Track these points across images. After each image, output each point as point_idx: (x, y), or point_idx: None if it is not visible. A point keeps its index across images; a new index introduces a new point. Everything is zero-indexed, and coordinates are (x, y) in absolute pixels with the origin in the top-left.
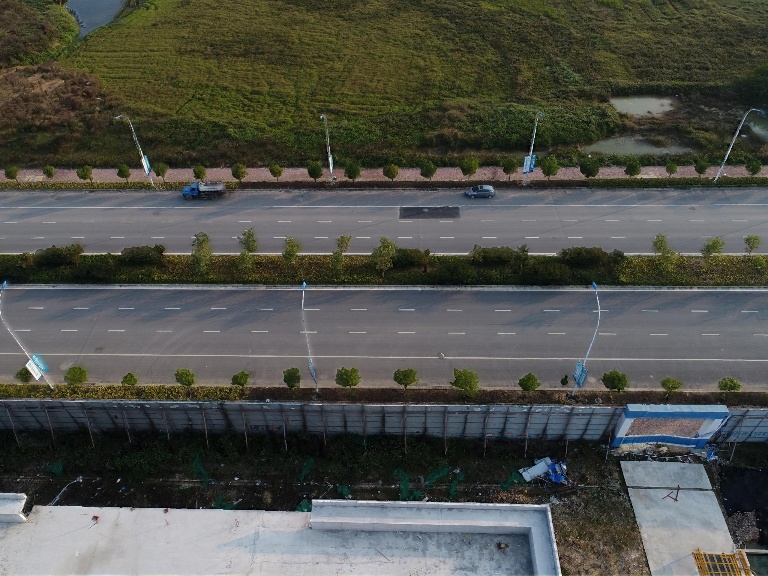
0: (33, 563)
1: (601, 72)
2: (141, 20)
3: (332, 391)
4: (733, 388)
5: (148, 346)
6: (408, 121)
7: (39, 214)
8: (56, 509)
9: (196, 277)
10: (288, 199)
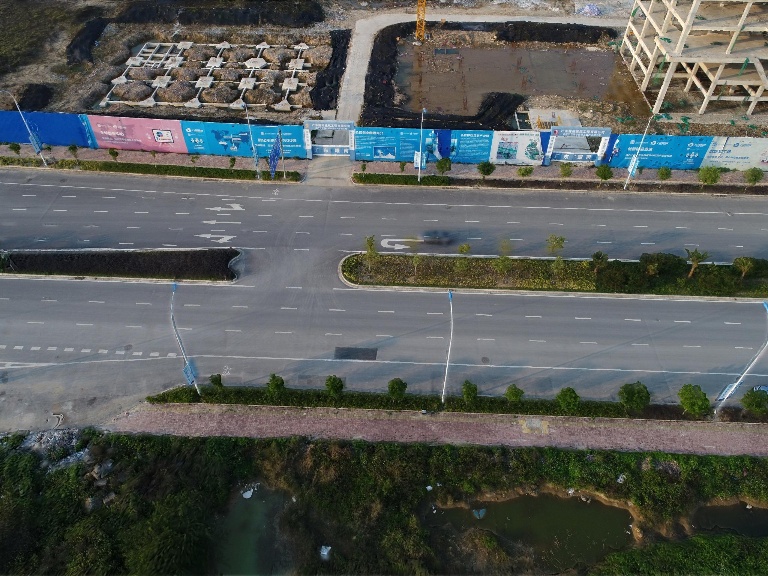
0: None
1: None
2: None
3: None
4: None
5: None
6: None
7: None
8: None
9: None
10: None
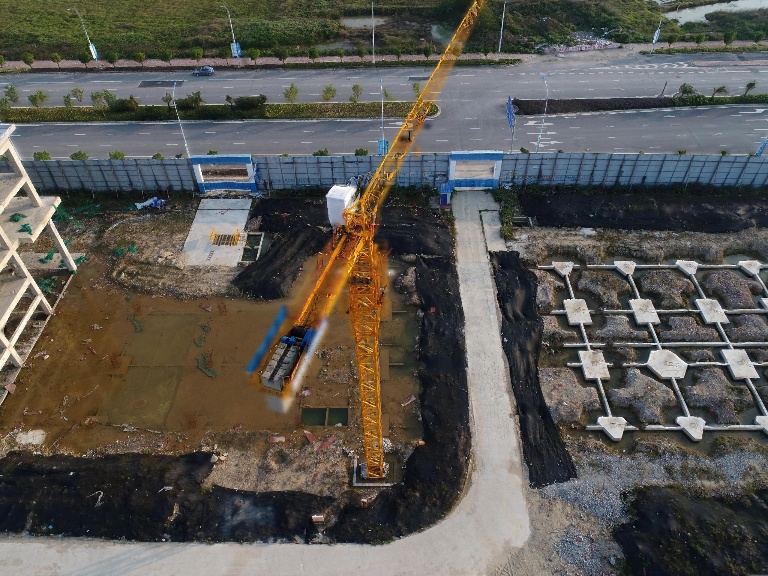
0: None
1: (345, 0)
2: None
3: None
4: None
5: None
6: (179, 32)
7: None
8: None
9: None
10: (63, 78)
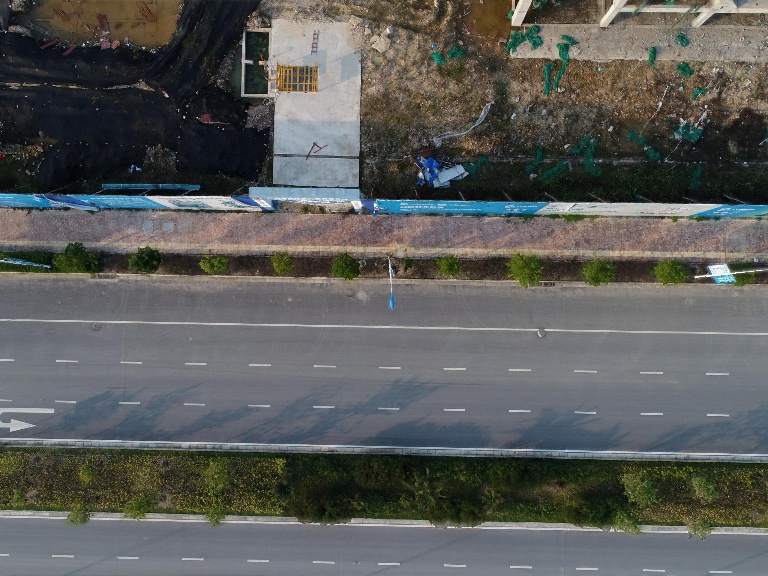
0: None
1: None
2: None
3: None
4: (213, 258)
5: None
6: None
7: None
8: None
9: None
10: None
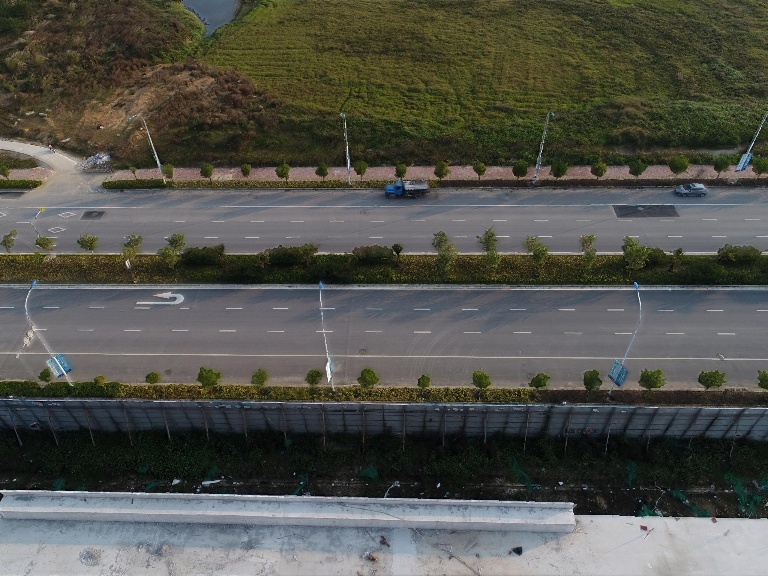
0: (609, 575)
1: (762, 69)
2: (265, 17)
3: (625, 393)
4: None
5: (413, 347)
6: (585, 119)
7: (243, 213)
8: (596, 518)
9: (435, 277)
10: (494, 198)
